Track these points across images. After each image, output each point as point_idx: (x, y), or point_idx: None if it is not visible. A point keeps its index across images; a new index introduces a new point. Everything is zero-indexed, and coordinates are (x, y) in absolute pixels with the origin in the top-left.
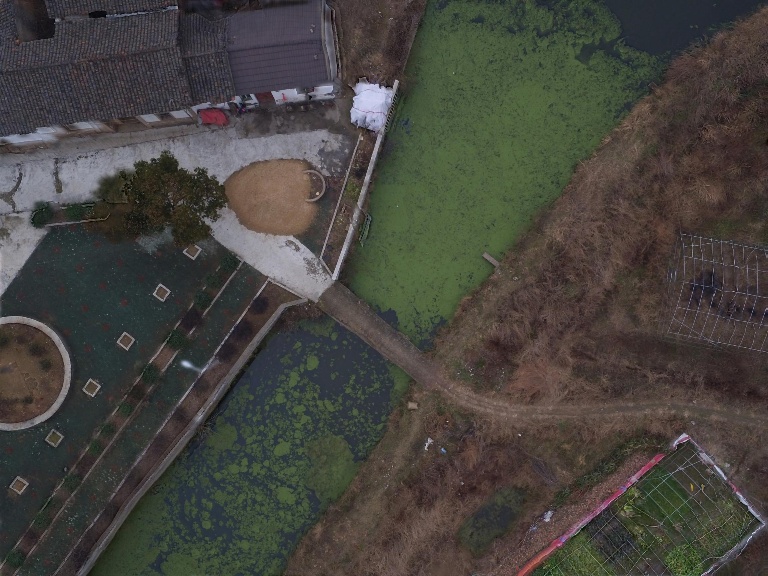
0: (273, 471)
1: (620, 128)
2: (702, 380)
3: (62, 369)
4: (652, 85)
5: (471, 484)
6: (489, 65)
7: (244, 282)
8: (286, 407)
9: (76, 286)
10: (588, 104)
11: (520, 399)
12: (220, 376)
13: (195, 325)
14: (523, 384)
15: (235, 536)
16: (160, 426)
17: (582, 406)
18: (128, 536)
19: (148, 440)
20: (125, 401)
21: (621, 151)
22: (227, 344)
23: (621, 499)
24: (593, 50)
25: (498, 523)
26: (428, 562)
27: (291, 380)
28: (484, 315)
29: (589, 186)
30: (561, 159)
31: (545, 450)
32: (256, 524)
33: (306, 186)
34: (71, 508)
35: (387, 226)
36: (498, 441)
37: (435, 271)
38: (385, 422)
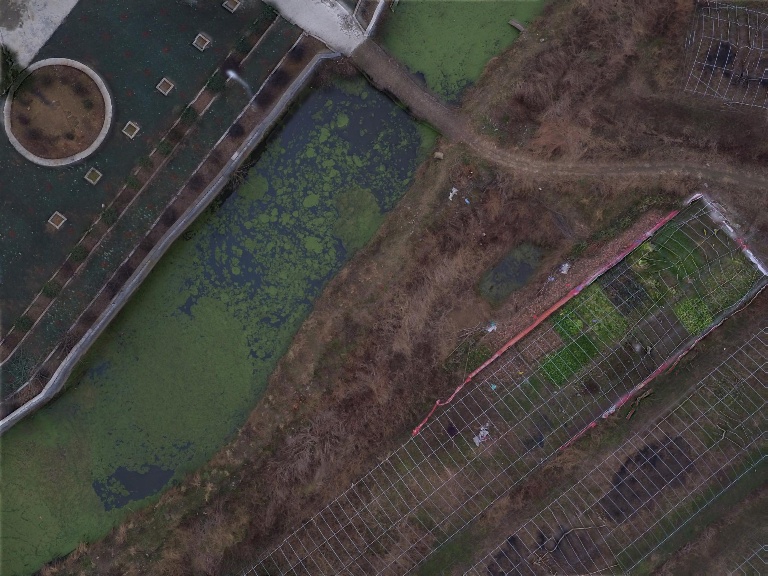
0: (302, 221)
1: None
2: (715, 145)
3: (103, 110)
4: None
5: (493, 234)
6: None
7: (280, 35)
8: (316, 161)
9: (119, 34)
10: None
11: (541, 156)
12: (254, 123)
13: (232, 73)
14: (544, 141)
15: (263, 282)
16: (195, 168)
17: (600, 165)
18: (160, 279)
19: (183, 181)
20: (162, 143)
21: None
22: (262, 94)
23: (636, 253)
24: None
25: (517, 278)
26: (449, 308)
27: (321, 136)
28: (509, 75)
29: None
30: None
31: (564, 205)
32: (284, 271)
33: None
34: (107, 243)
35: None
36: (519, 194)
37: (462, 37)
38: (411, 177)
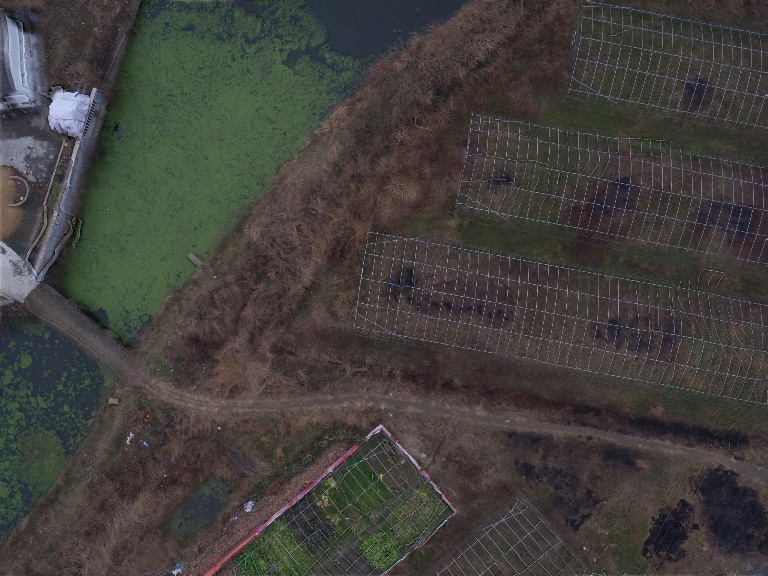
0: None
1: (319, 130)
2: (399, 373)
3: None
4: (354, 88)
5: (173, 476)
6: (199, 72)
7: None
8: (1, 404)
9: None
10: (294, 108)
11: (220, 394)
12: None
13: None
14: (223, 379)
15: None
16: None
17: (281, 400)
18: None
19: None
20: None
21: (321, 153)
22: None
23: (317, 489)
24: (299, 55)
25: (206, 514)
26: (132, 552)
27: (5, 378)
28: (184, 313)
29: (289, 187)
30: (266, 161)
31: (245, 443)
32: None
33: (10, 191)
34: None
35: (97, 229)
36: (198, 434)
37: (144, 271)
38: (94, 417)
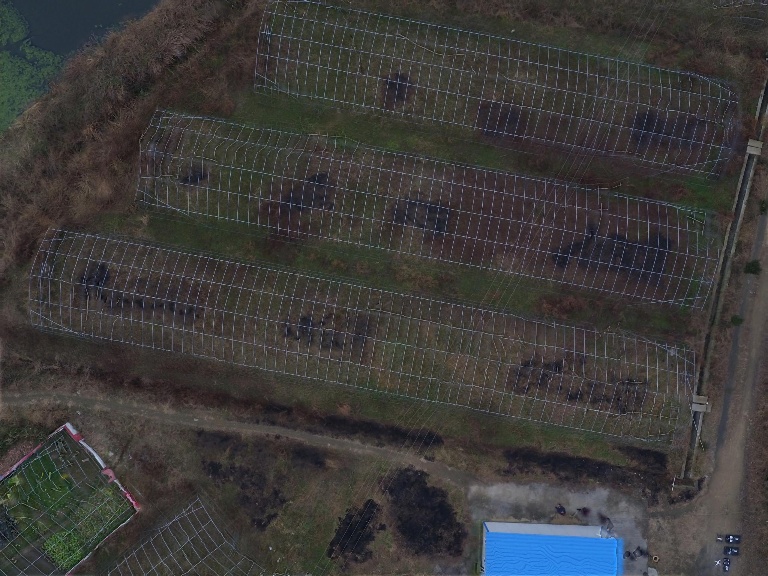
0: None
1: (13, 126)
2: (88, 371)
3: None
4: (51, 84)
5: None
6: None
7: None
8: None
9: None
10: None
11: None
12: None
13: None
14: None
15: None
16: None
17: None
18: None
19: None
20: None
21: (14, 149)
22: None
23: (1, 487)
24: None
25: None
26: None
27: None
28: None
29: None
30: None
31: None
32: None
33: None
34: None
35: None
36: None
37: None
38: None
